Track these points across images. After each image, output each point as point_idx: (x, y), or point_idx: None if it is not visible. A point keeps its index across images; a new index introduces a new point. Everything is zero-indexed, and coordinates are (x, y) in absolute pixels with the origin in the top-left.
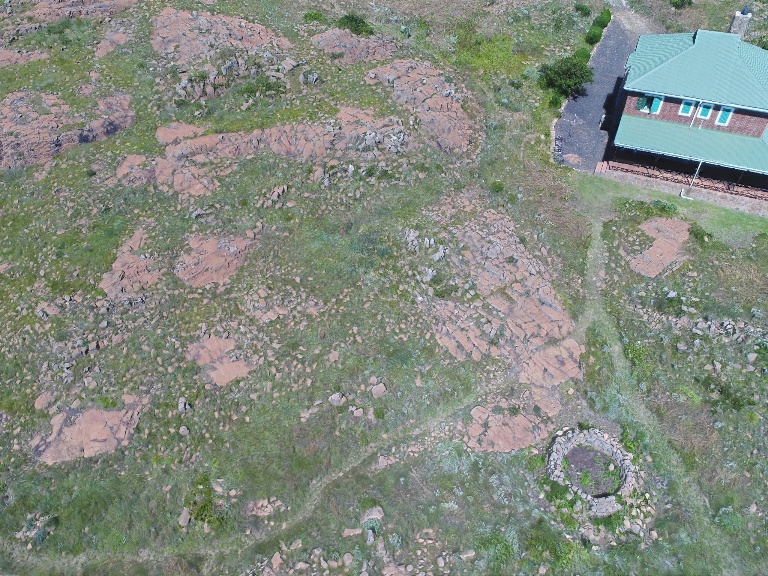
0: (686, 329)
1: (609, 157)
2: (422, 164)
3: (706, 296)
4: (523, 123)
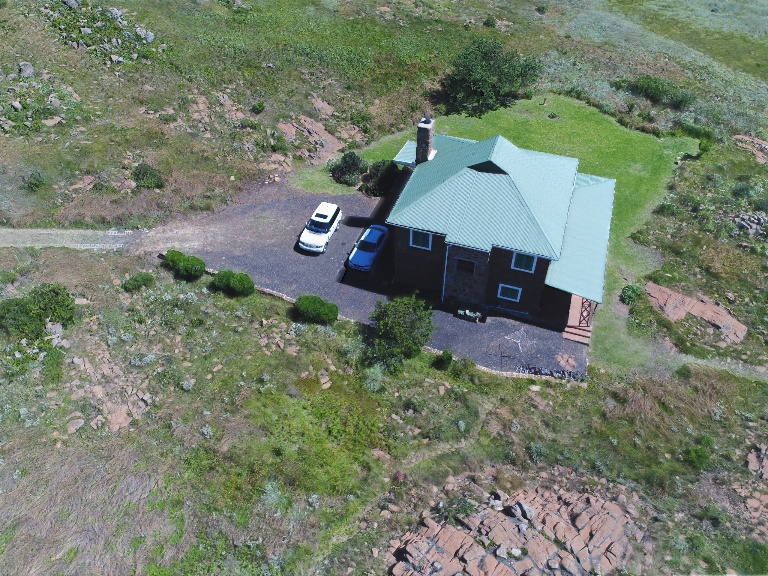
0: None
1: (559, 323)
2: (712, 571)
3: (765, 292)
4: (519, 407)
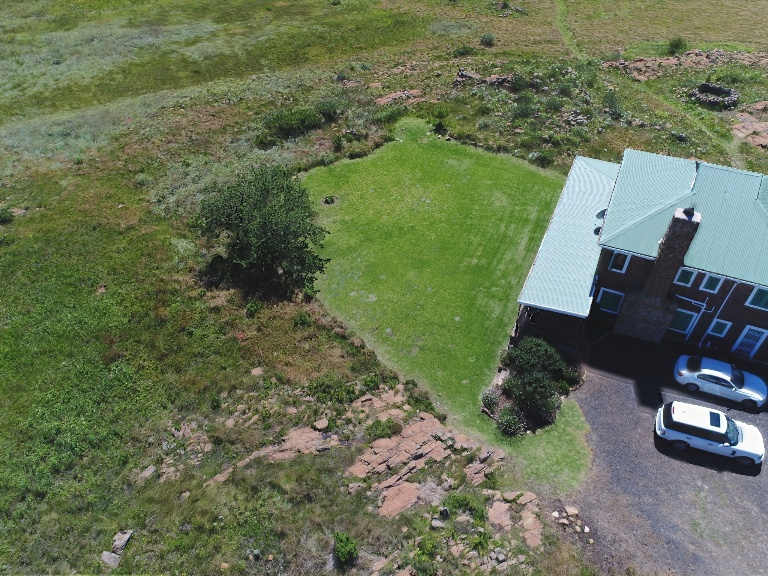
0: (667, 131)
1: None
2: None
3: None
4: None
